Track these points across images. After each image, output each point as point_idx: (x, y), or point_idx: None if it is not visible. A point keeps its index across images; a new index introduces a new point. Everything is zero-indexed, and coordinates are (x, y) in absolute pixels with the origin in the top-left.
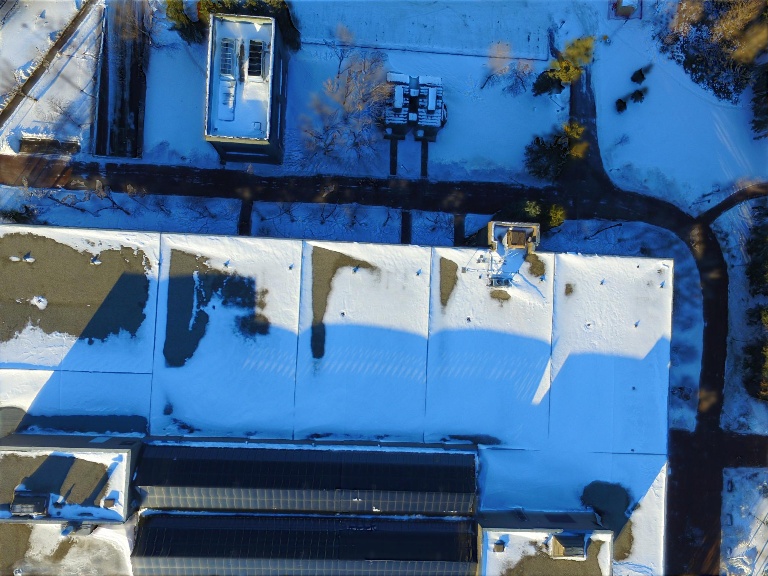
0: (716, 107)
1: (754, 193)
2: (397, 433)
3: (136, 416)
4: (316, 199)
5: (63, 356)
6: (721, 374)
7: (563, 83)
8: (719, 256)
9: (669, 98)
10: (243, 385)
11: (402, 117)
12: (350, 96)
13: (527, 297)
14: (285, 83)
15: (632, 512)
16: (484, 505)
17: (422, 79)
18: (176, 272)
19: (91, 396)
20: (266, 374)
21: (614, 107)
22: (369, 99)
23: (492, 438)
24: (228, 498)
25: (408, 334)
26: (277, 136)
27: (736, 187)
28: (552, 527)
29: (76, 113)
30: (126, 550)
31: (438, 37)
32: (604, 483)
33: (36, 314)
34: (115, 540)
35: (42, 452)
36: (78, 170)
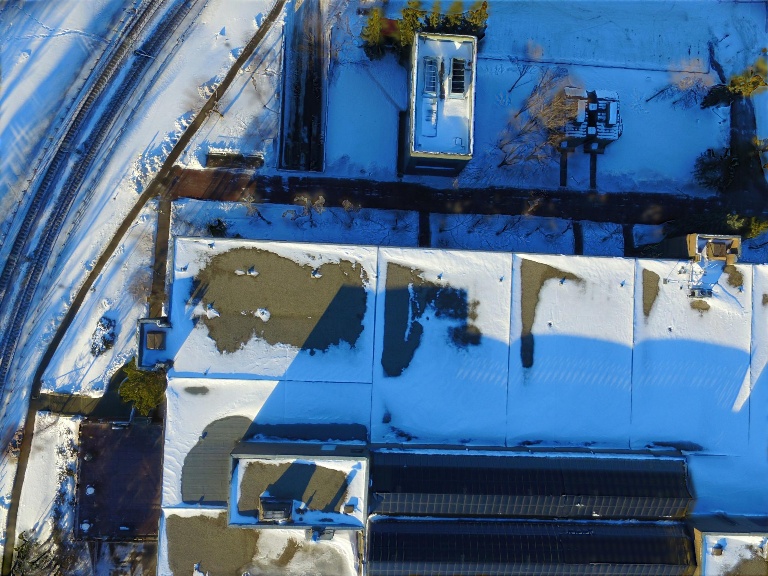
0: None
1: None
2: (604, 440)
3: (356, 424)
4: (490, 211)
5: (287, 366)
6: None
7: None
8: None
9: None
10: (457, 394)
11: (582, 131)
12: (528, 110)
13: (726, 307)
14: None
15: None
16: None
17: (599, 93)
18: (392, 285)
19: (314, 405)
20: (479, 383)
21: None
22: (549, 113)
23: (694, 444)
24: (457, 504)
25: (613, 344)
26: None
27: None
28: (766, 531)
29: (260, 128)
30: (349, 554)
31: (602, 51)
32: None
33: (260, 326)
34: (338, 544)
35: (285, 460)
36: (262, 184)
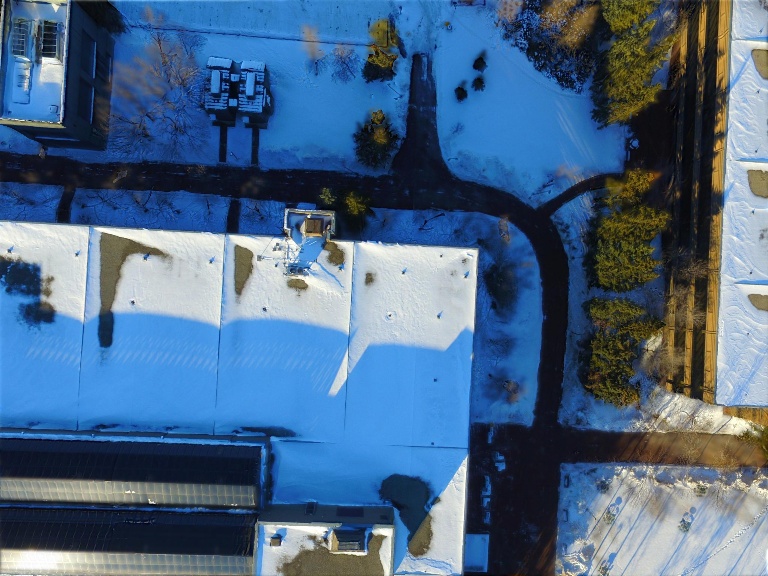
0: (559, 96)
1: (597, 184)
2: (187, 424)
3: None
4: (141, 186)
5: None
6: (560, 368)
7: (402, 70)
8: (559, 248)
9: (511, 86)
10: (26, 374)
11: (221, 102)
12: (171, 81)
13: (325, 286)
14: (109, 67)
15: (432, 507)
16: (277, 498)
17: (244, 64)
18: None
19: None
20: (50, 363)
21: (454, 95)
22: (188, 84)
23: (286, 430)
24: None
25: (200, 323)
26: (90, 121)
27: (578, 178)
28: (333, 521)
29: None
30: None
31: (274, 22)
32: (403, 477)
33: None
34: None
35: None
36: None
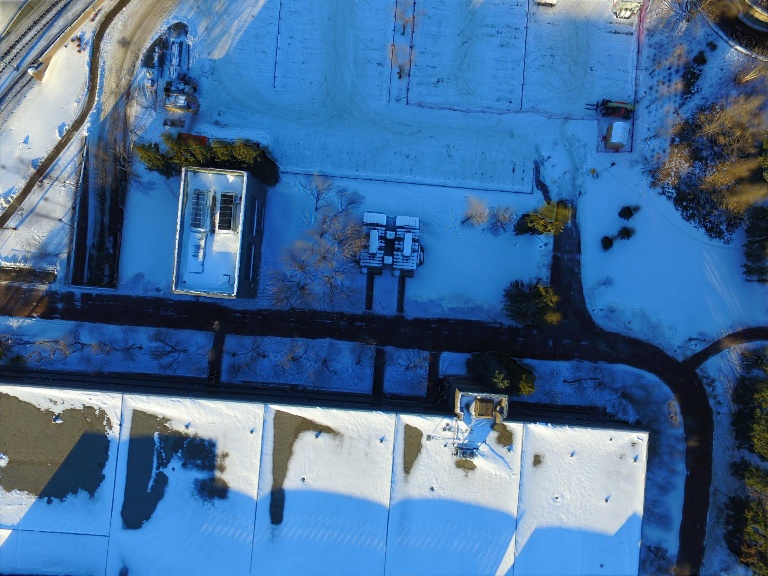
0: (707, 246)
1: (744, 337)
2: None
3: None
4: (289, 334)
5: (22, 515)
6: (703, 525)
7: (547, 218)
8: (705, 402)
9: (658, 235)
10: (200, 550)
11: (377, 260)
12: (326, 235)
13: (493, 468)
14: (262, 217)
15: None
16: None
17: (399, 220)
18: (137, 433)
19: (48, 556)
20: (223, 539)
21: (599, 244)
22: (344, 240)
23: None
24: None
25: (369, 502)
26: (249, 278)
27: (725, 331)
28: None
29: (54, 242)
30: None
31: (420, 167)
32: None
33: None
34: None
35: None
36: (54, 299)
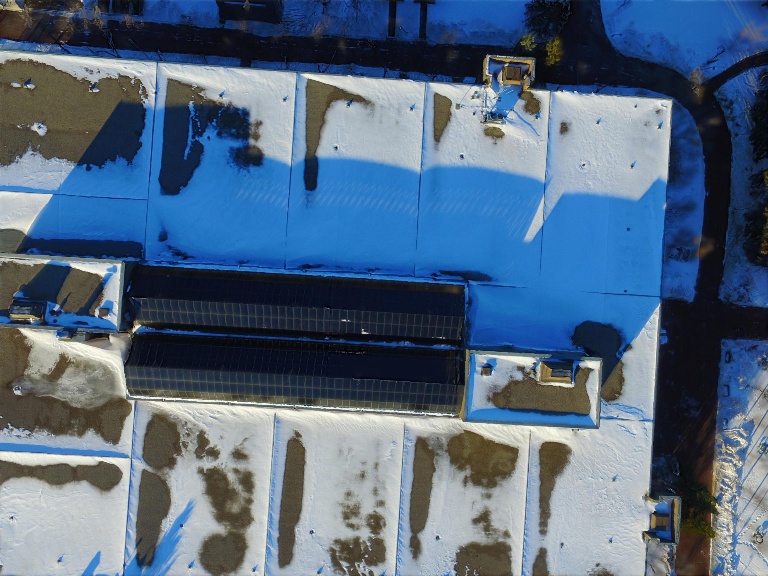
0: None
1: (761, 61)
2: (388, 266)
3: (132, 242)
4: (314, 59)
5: (62, 181)
6: (722, 245)
7: None
8: (723, 124)
9: None
10: (236, 214)
11: None
12: None
13: (521, 134)
14: None
15: (623, 353)
16: (474, 341)
17: None
18: (172, 101)
19: (88, 220)
20: (259, 204)
21: None
22: None
23: (483, 275)
24: (219, 314)
25: (401, 169)
26: None
27: (742, 54)
28: None
29: None
30: (121, 371)
31: None
32: (596, 324)
33: (36, 140)
34: (110, 361)
35: (40, 261)
36: (81, 27)
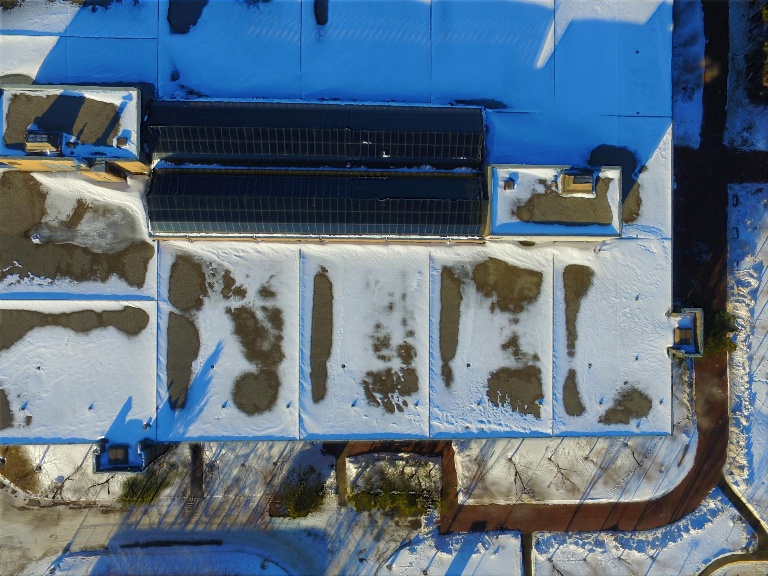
0: None
1: None
2: (404, 98)
3: (144, 82)
4: None
5: (68, 23)
6: (724, 91)
7: None
8: None
9: None
10: (249, 51)
11: None
12: None
13: None
14: None
15: (639, 175)
16: None
17: None
18: None
19: (98, 62)
20: (271, 40)
21: None
22: None
23: (498, 102)
24: (239, 142)
25: (411, 0)
26: None
27: None
28: None
29: None
30: (141, 213)
31: None
32: (611, 147)
33: None
34: (130, 204)
35: (53, 91)
36: None
